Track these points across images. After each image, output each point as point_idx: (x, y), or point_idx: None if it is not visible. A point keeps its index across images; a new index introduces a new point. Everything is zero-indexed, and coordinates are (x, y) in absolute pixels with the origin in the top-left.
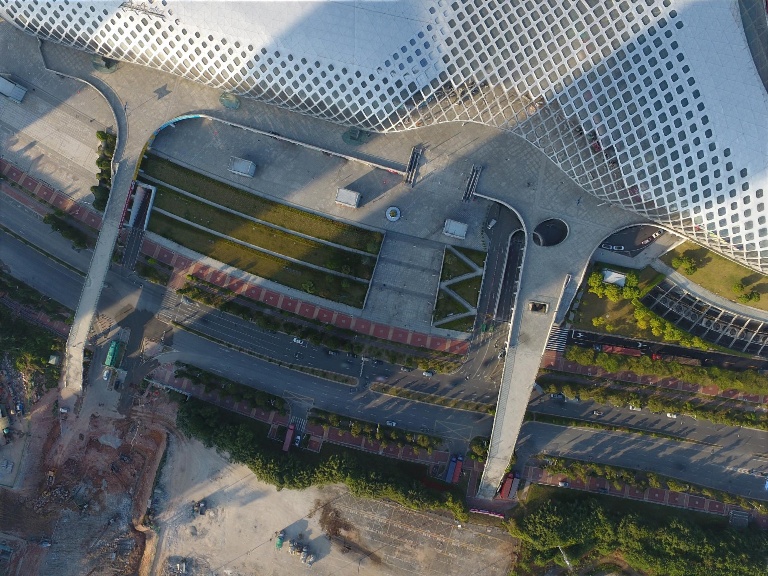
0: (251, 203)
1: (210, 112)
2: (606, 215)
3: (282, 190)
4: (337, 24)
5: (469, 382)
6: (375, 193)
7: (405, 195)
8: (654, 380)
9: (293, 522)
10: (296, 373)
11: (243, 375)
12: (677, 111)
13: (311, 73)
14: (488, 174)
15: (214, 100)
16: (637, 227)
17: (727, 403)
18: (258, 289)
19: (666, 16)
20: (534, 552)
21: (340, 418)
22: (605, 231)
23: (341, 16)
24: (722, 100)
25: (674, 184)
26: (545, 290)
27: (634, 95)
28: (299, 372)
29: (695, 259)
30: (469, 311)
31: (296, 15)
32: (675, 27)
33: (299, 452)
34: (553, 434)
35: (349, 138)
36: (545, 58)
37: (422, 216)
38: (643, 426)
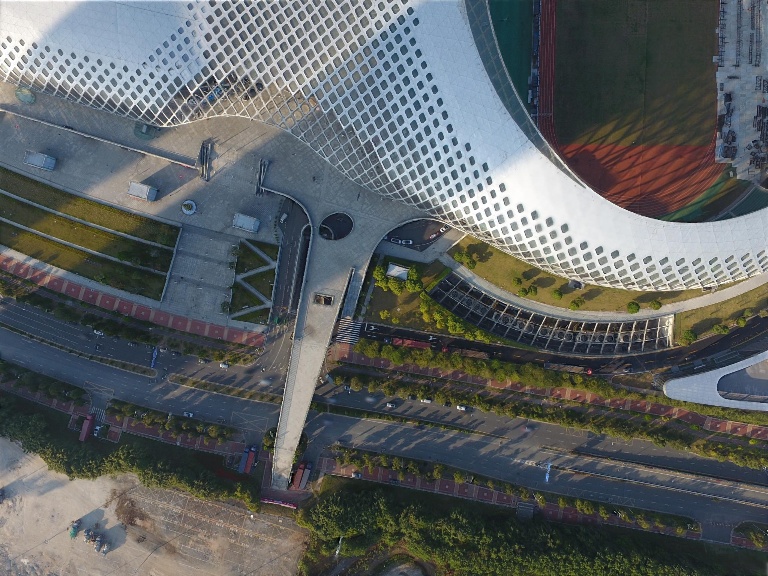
0: (51, 196)
1: (6, 106)
2: (389, 209)
3: (81, 183)
4: (100, 19)
5: (265, 374)
6: (172, 187)
7: (201, 189)
8: (444, 373)
9: (90, 511)
10: (96, 364)
11: (45, 366)
12: (420, 106)
13: (82, 68)
14: (275, 168)
15: (10, 94)
16: (424, 222)
17: (515, 396)
18: (60, 281)
19: (404, 13)
20: (320, 542)
21: (135, 409)
22: (388, 225)
23: (103, 12)
24: (457, 96)
25: (429, 178)
26: (330, 283)
27: (382, 90)
28: (99, 363)
29: (478, 253)
30: (264, 304)
31: (61, 10)
32: (412, 24)
33: (98, 442)
34: (347, 426)
35: (140, 132)
36: (299, 54)
37: (217, 210)
38: (434, 418)
